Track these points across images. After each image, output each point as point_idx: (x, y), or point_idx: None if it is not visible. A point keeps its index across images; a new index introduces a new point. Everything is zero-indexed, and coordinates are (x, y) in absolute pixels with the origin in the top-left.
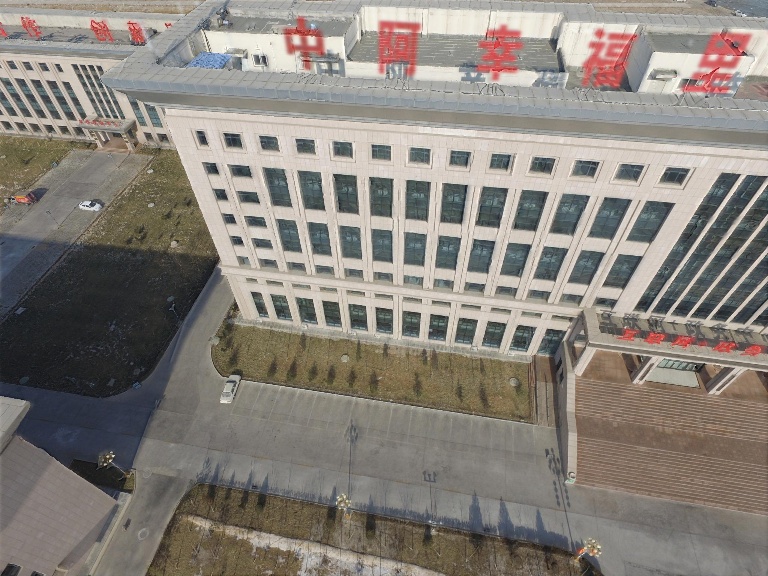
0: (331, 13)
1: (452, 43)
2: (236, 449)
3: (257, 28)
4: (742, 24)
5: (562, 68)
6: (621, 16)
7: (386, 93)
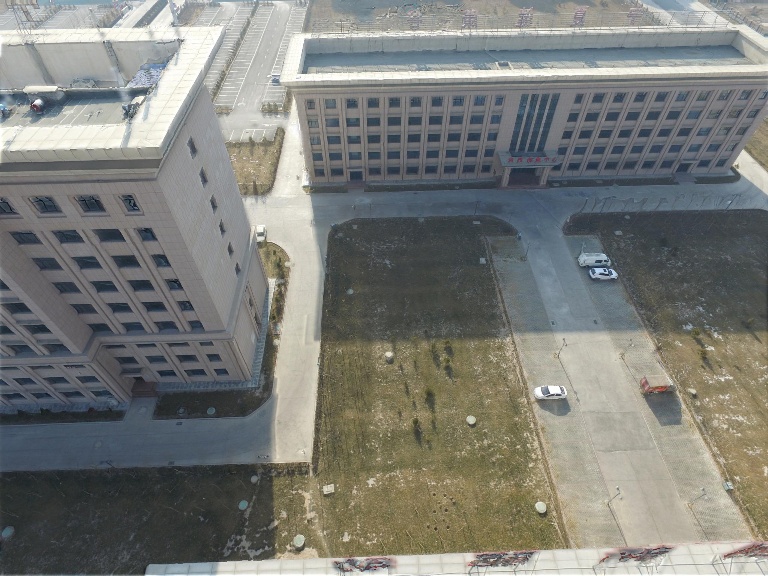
0: None
1: None
2: (247, 210)
3: (86, 115)
4: None
5: None
6: None
7: None
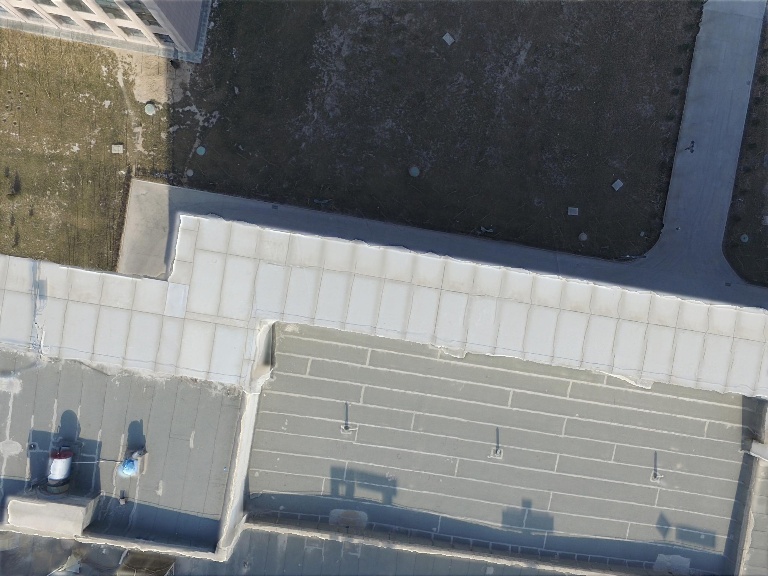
0: (170, 373)
1: (508, 379)
2: None
3: None
4: None
5: (735, 555)
6: None
7: None
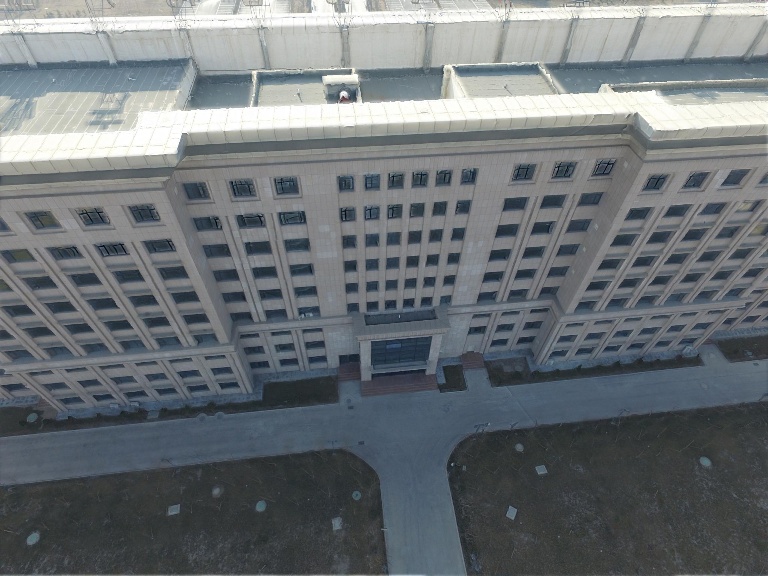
0: None
1: None
2: None
3: None
4: (451, 103)
5: None
6: (599, 104)
7: (699, 5)
